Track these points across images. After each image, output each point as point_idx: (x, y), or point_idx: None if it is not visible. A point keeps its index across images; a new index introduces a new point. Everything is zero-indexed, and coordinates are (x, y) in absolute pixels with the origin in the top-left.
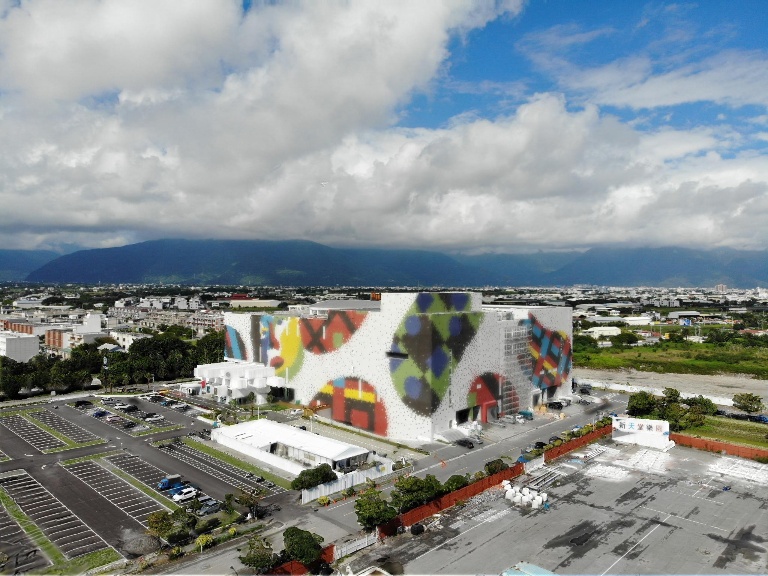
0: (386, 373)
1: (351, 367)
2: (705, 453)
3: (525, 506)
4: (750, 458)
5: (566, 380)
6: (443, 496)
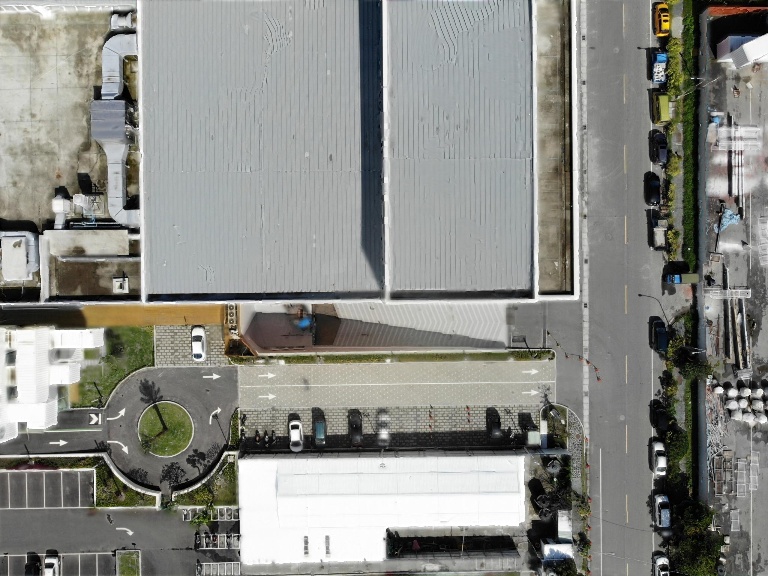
0: None
1: None
2: None
3: (762, 423)
4: None
5: None
6: None
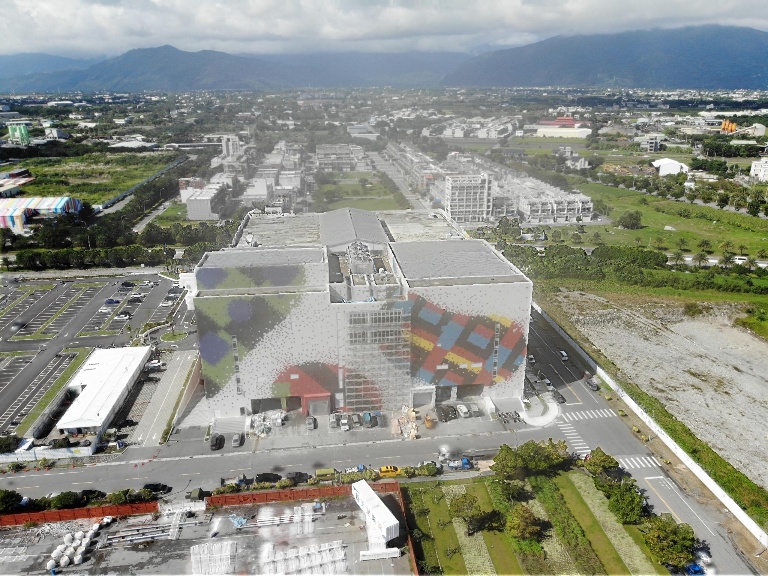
0: None
1: None
2: None
3: None
4: None
5: (509, 378)
6: (40, 509)
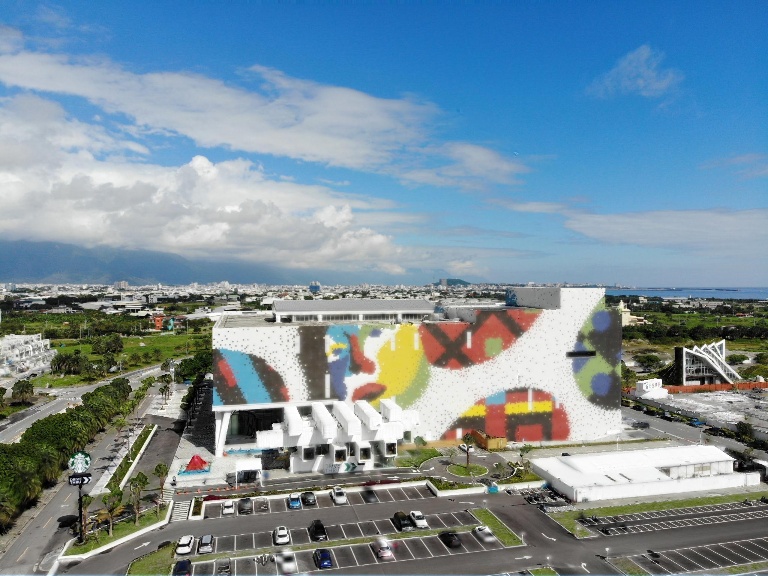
0: (569, 375)
1: (516, 376)
2: None
3: None
4: (693, 392)
5: None
6: None
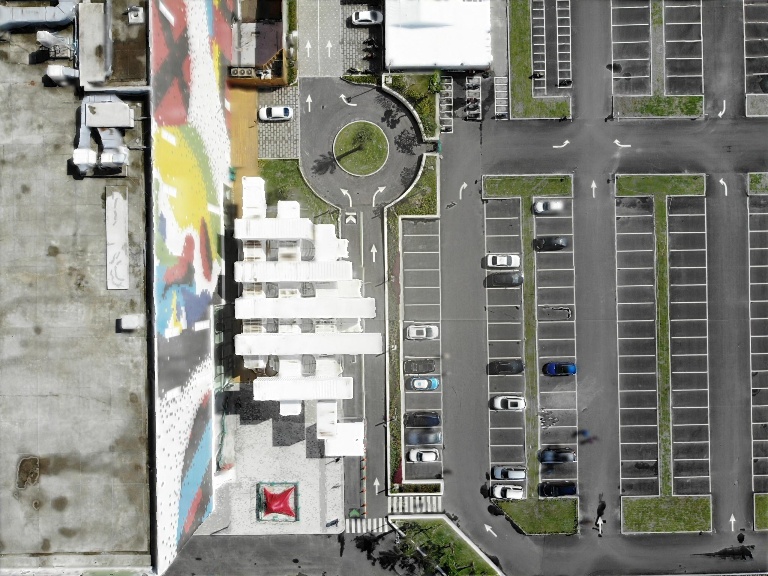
0: None
1: None
2: None
3: None
4: None
5: None
6: None
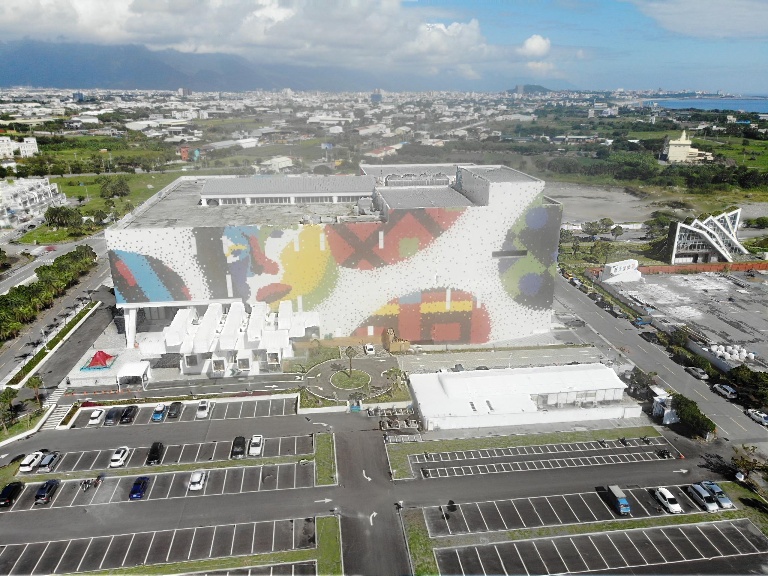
0: (493, 275)
1: (434, 277)
2: (655, 276)
3: (747, 360)
4: (675, 273)
5: None
6: None
